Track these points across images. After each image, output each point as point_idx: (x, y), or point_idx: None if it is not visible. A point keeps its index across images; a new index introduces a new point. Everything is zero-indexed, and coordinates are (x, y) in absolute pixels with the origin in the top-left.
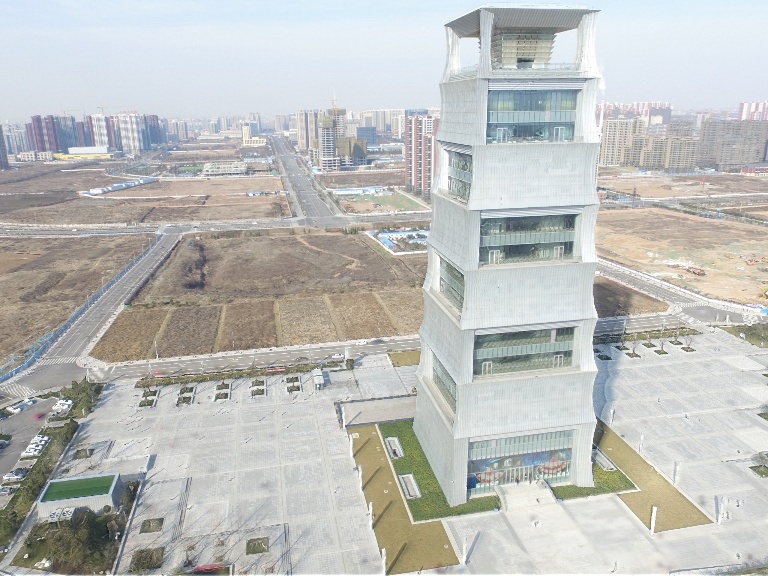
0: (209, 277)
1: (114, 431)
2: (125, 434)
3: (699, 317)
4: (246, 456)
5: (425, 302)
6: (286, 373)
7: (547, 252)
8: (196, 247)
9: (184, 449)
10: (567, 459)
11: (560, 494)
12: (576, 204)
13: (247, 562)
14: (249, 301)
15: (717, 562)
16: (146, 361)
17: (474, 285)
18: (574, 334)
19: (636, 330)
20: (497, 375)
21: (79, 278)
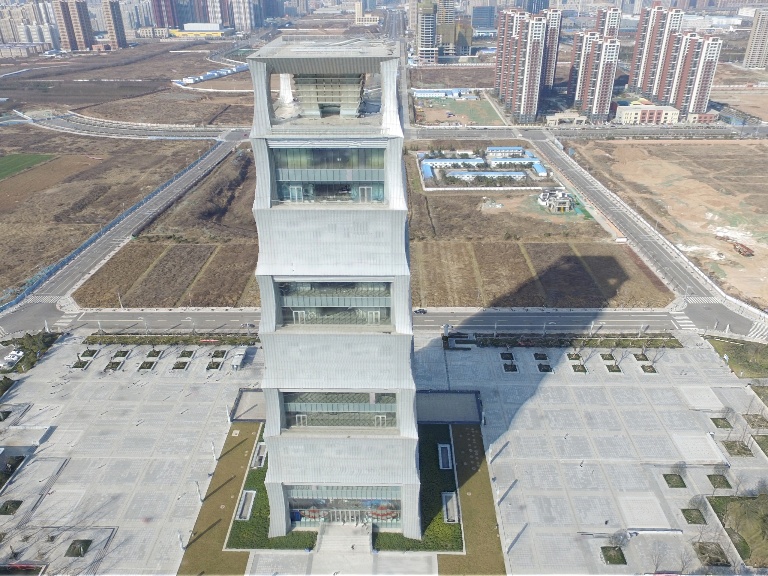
0: (236, 201)
1: (39, 393)
2: (45, 398)
3: (698, 320)
4: (128, 441)
5: None
6: (219, 344)
7: None
8: (242, 162)
9: (82, 424)
10: (397, 509)
11: (380, 543)
12: (381, 274)
13: (60, 564)
14: (244, 242)
15: None
16: (113, 310)
17: (272, 346)
18: (396, 398)
19: (611, 330)
20: (312, 428)
21: (118, 194)
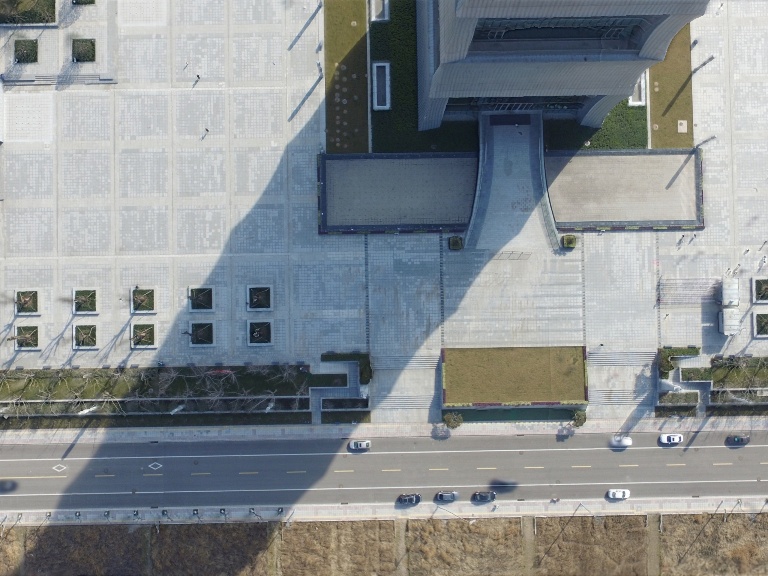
0: None
1: None
2: None
3: None
4: None
5: None
6: None
7: None
8: None
9: None
10: None
11: None
12: None
13: None
14: None
15: None
16: None
17: None
18: None
19: (52, 438)
20: None
21: None
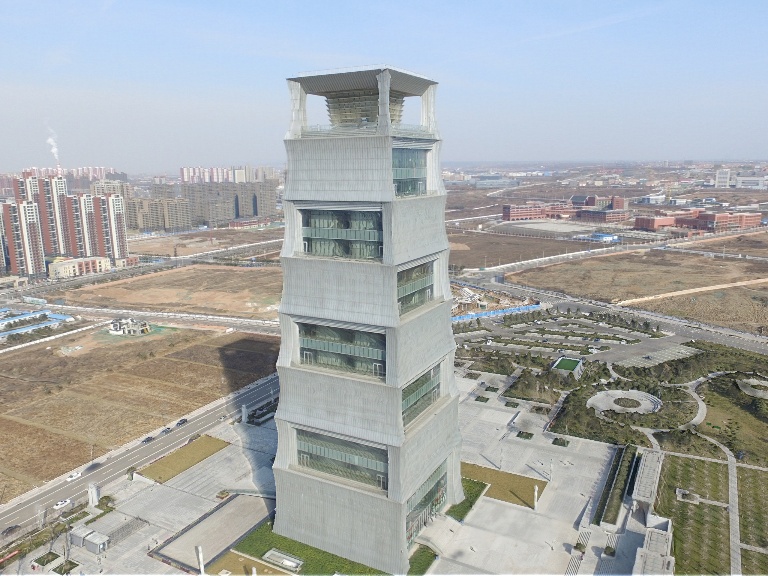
0: None
1: None
2: None
3: None
4: None
5: (284, 380)
6: (22, 556)
7: (417, 297)
8: None
9: None
10: (445, 484)
11: (456, 517)
12: (441, 249)
13: None
14: None
15: (581, 505)
16: None
17: (399, 340)
18: (441, 367)
19: None
20: (410, 426)
21: None
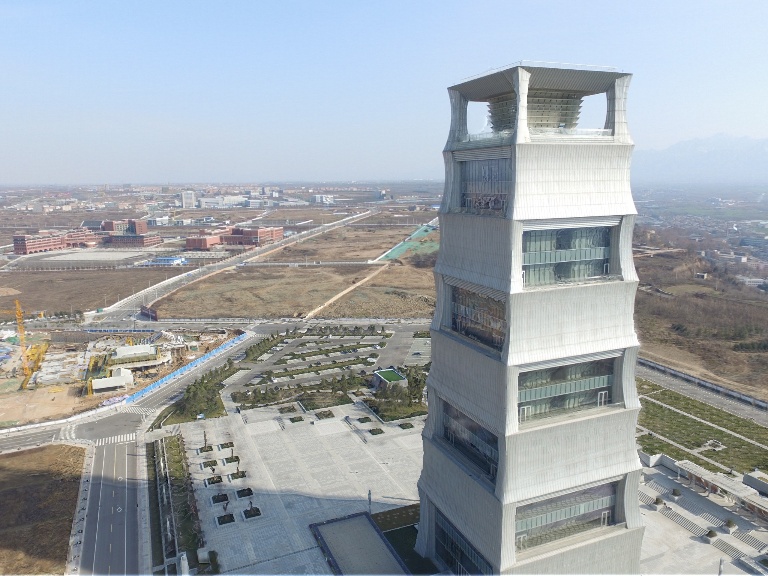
0: None
1: None
2: None
3: (118, 433)
4: None
5: (514, 452)
6: None
7: None
8: None
9: None
10: None
11: None
12: None
13: None
14: None
15: None
16: None
17: None
18: None
19: (141, 472)
20: None
21: None
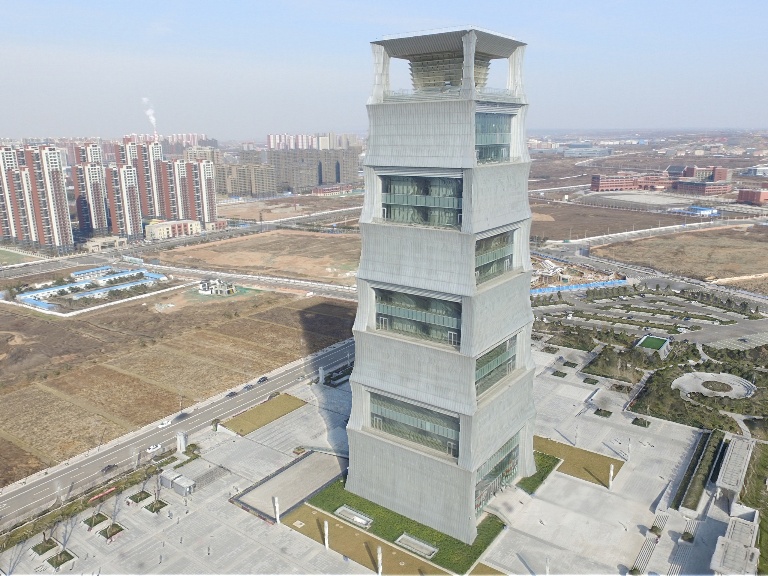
0: None
1: None
2: None
3: None
4: None
5: (360, 344)
6: (119, 492)
7: (495, 267)
8: None
9: None
10: (516, 456)
11: (526, 490)
12: (523, 219)
13: None
14: None
15: (659, 488)
16: None
17: (475, 309)
18: (517, 339)
19: None
20: (483, 396)
21: None
